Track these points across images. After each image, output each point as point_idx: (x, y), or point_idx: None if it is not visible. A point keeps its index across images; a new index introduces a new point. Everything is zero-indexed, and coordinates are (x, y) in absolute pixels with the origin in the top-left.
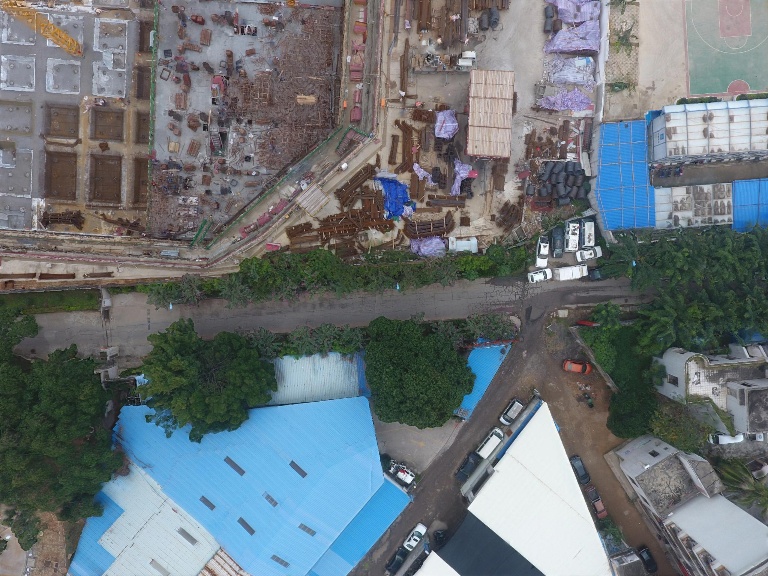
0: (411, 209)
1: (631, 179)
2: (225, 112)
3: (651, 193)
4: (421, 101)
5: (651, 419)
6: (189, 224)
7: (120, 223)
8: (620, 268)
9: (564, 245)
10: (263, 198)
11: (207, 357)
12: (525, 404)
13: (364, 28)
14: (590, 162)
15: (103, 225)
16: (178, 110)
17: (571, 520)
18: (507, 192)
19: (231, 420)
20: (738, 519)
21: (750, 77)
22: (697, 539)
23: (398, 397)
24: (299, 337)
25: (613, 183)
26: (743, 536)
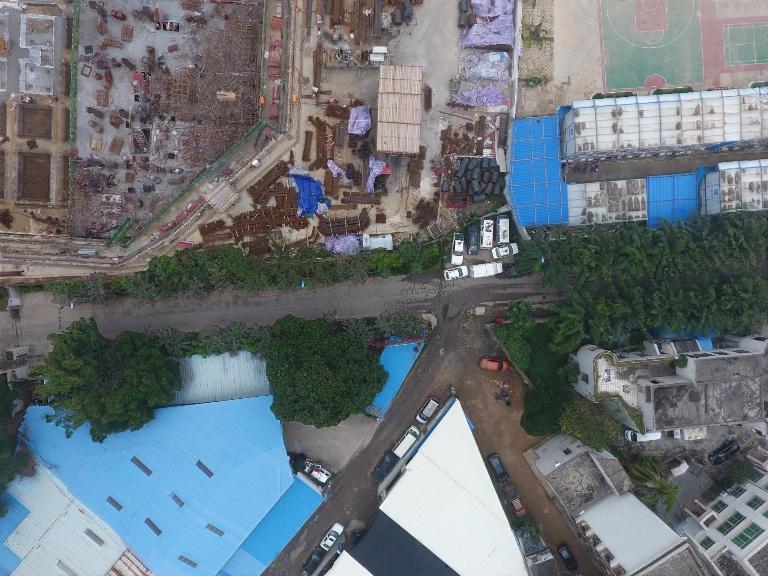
0: (326, 206)
1: (544, 175)
2: (148, 109)
3: (564, 189)
4: (335, 97)
5: (562, 417)
6: (113, 222)
7: (49, 221)
8: (532, 265)
9: (479, 242)
10: (181, 196)
11: (107, 356)
12: (442, 402)
13: (281, 23)
14: (505, 158)
15: (32, 224)
16: (98, 107)
17: (485, 519)
18: (423, 189)
19: (130, 420)
20: (642, 517)
21: (667, 72)
22: (602, 537)
23: (292, 396)
24: (207, 336)
25: (526, 179)
26: (643, 534)
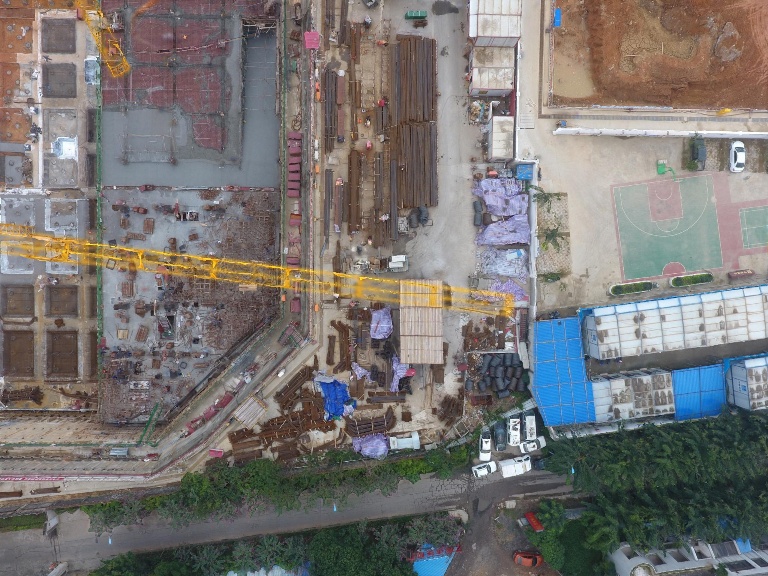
0: (351, 407)
1: (568, 375)
2: (171, 296)
3: (589, 389)
4: (356, 300)
5: None
6: (141, 408)
7: (78, 396)
8: None
9: (506, 438)
10: (208, 392)
11: None
12: None
13: (299, 221)
14: (528, 353)
15: (62, 399)
16: (124, 301)
17: None
18: (447, 384)
19: None
20: None
21: (685, 258)
22: None
23: None
24: (242, 554)
25: (550, 380)
26: None
